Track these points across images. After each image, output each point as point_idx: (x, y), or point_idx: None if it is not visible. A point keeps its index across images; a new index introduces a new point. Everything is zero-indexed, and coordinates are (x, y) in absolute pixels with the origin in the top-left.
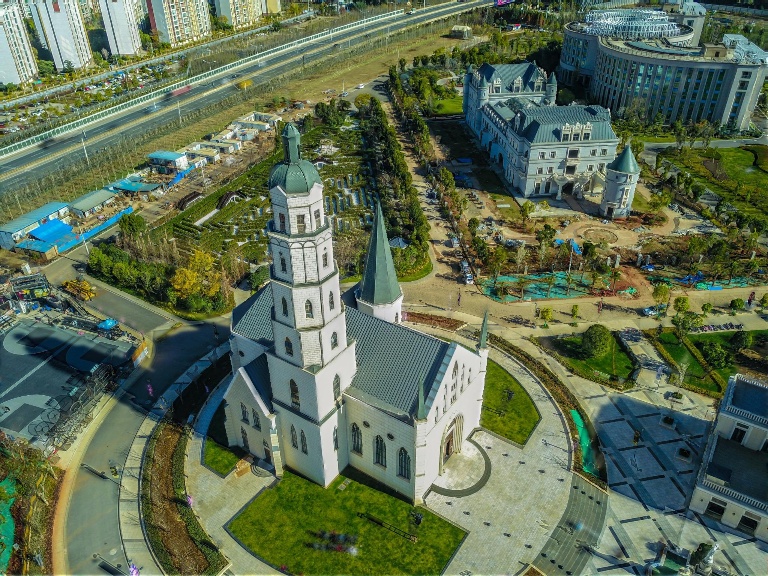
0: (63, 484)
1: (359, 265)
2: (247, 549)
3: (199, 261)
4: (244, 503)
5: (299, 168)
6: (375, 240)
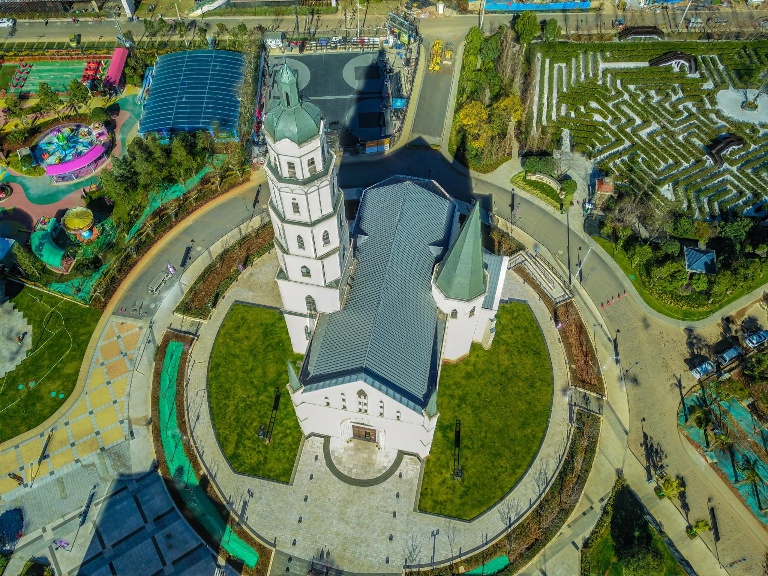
0: (239, 186)
1: (631, 241)
2: (221, 326)
3: (504, 107)
4: (260, 303)
5: (280, 115)
6: (460, 233)
